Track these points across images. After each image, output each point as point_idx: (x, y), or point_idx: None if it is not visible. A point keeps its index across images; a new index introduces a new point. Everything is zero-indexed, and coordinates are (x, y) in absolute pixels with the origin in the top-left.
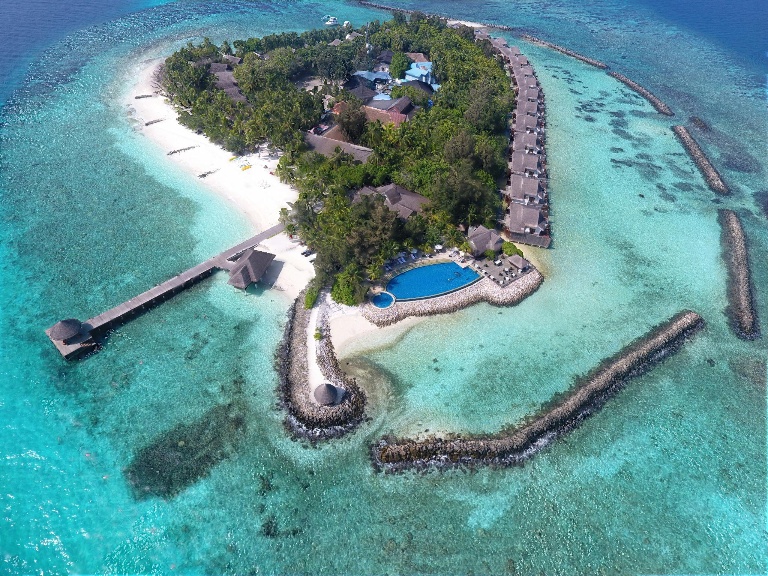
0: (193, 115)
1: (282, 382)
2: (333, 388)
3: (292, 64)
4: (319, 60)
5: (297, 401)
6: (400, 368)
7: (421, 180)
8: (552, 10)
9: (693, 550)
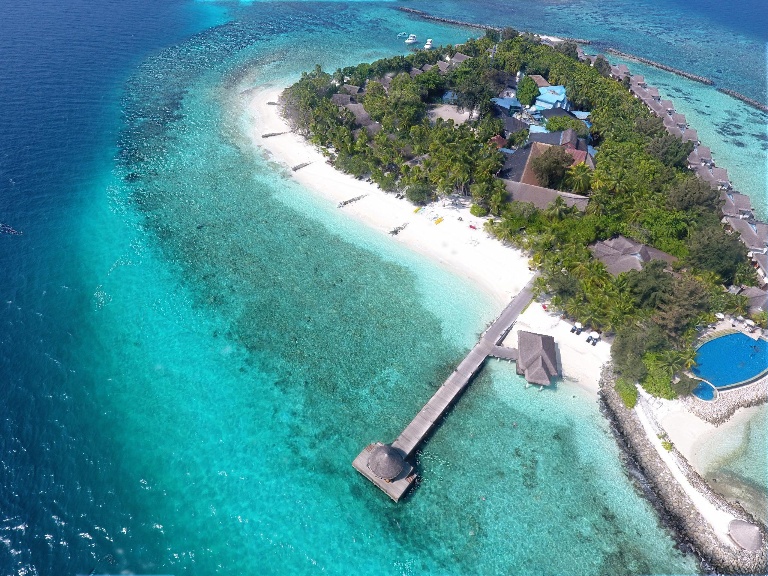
0: (350, 158)
1: (660, 514)
2: None
3: (419, 93)
4: (466, 90)
5: (706, 544)
6: None
7: (656, 232)
8: (614, 20)
9: None
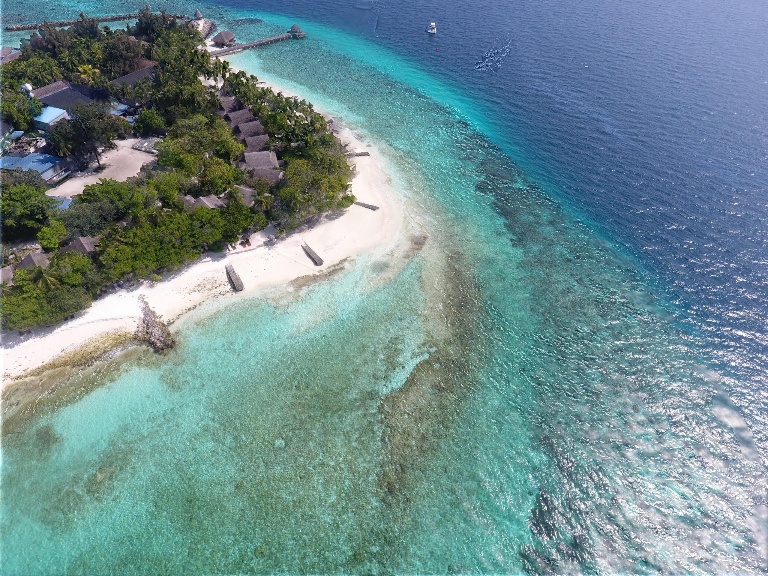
0: None
1: None
2: None
3: None
4: None
5: None
6: None
7: None
8: None
9: (105, 7)
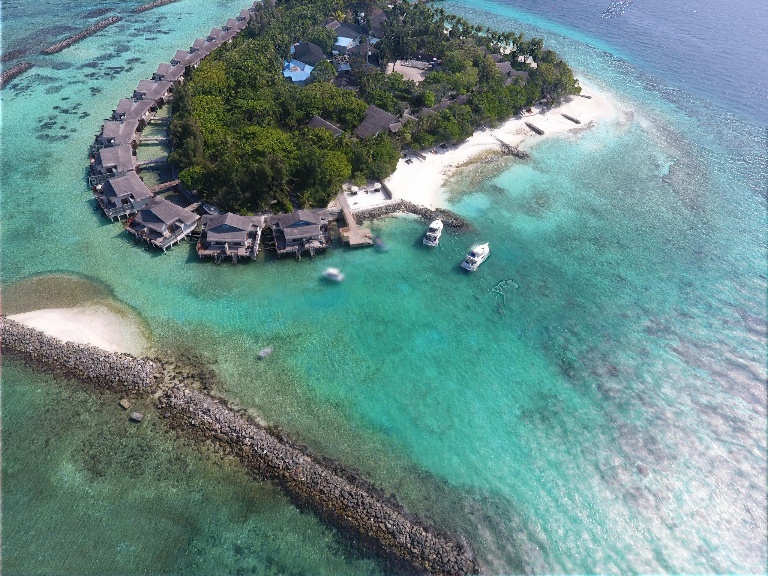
0: None
1: None
2: None
3: None
4: None
5: None
6: None
7: None
8: None
9: None
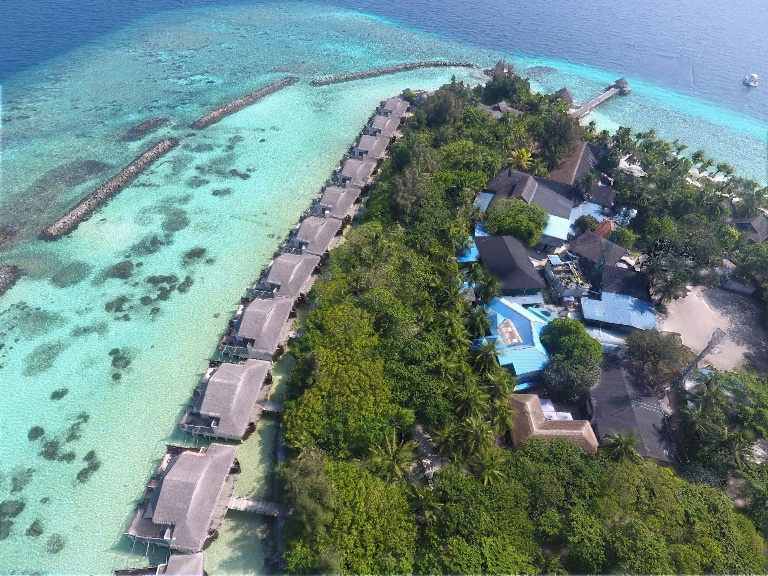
0: None
1: None
2: (498, 63)
3: None
4: None
5: None
6: (471, 79)
7: None
8: None
9: None
